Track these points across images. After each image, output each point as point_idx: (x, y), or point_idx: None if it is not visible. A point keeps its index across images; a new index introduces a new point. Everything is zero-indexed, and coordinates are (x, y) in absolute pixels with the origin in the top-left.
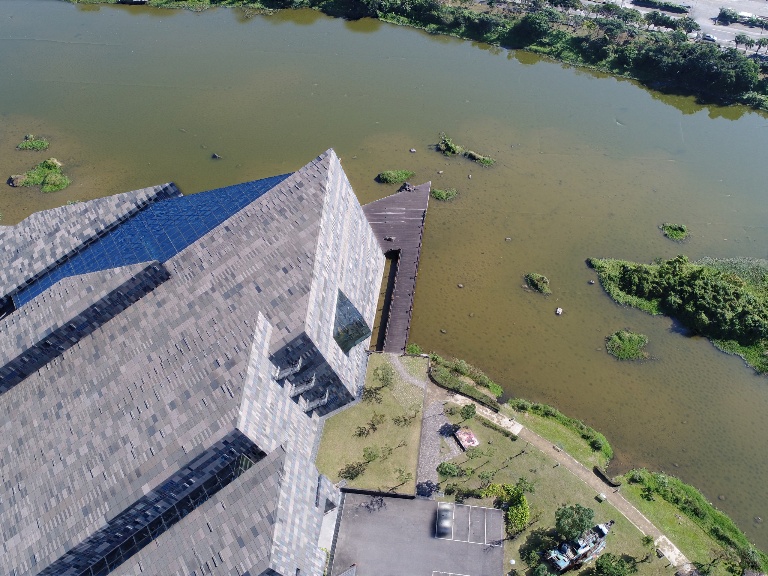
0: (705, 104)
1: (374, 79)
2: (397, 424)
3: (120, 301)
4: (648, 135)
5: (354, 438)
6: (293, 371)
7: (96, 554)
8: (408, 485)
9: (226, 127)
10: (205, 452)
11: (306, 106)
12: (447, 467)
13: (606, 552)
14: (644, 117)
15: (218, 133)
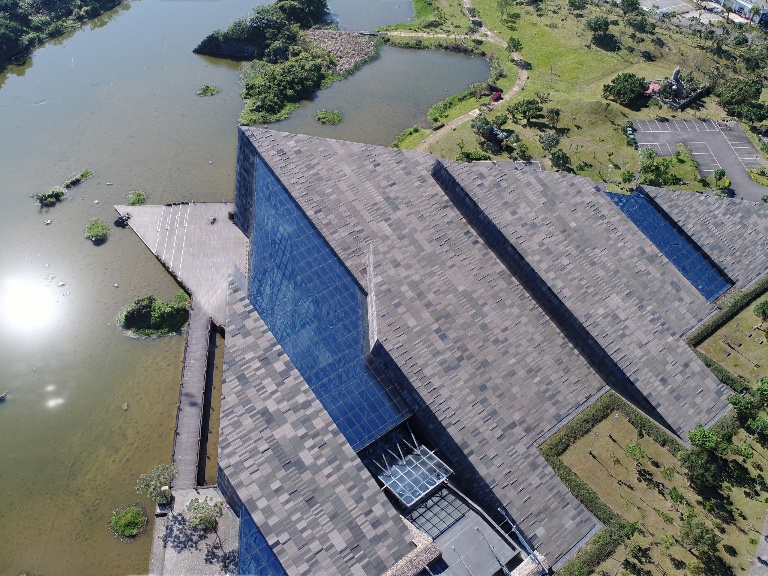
0: (25, 62)
1: None
2: None
3: None
4: (67, 91)
5: None
6: None
7: None
8: None
9: None
10: None
11: None
12: None
13: None
14: (36, 90)
15: None
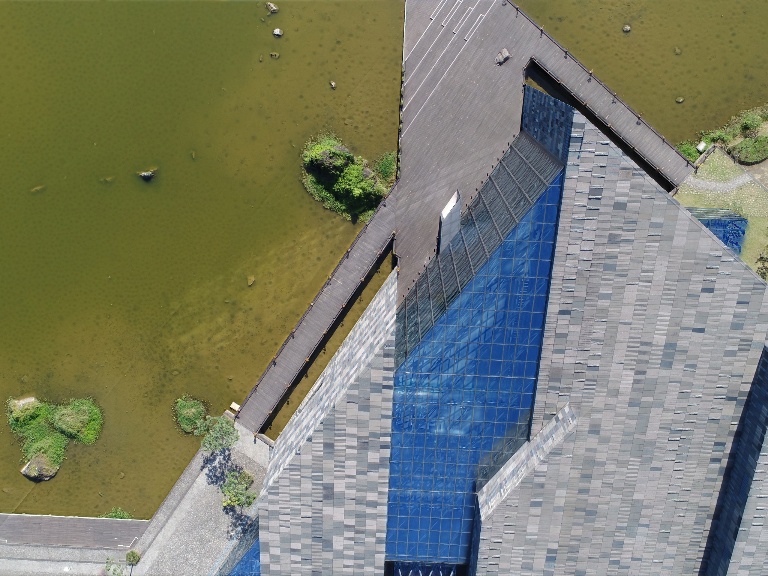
0: None
1: None
2: None
3: None
4: None
5: None
6: None
7: None
8: None
9: (69, 121)
10: None
11: None
12: None
13: None
14: None
15: (80, 142)
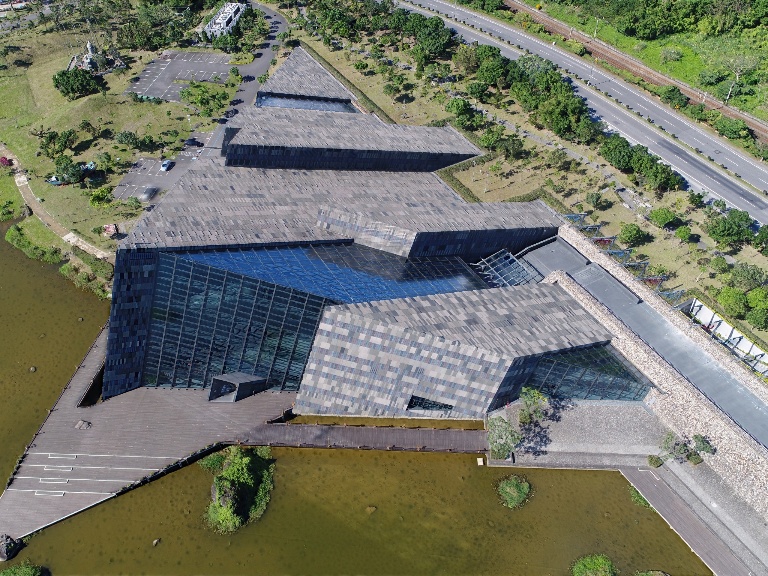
0: None
1: None
2: None
3: None
4: None
5: None
6: None
7: None
8: None
9: None
10: None
11: None
12: (134, 198)
13: None
14: None
15: None
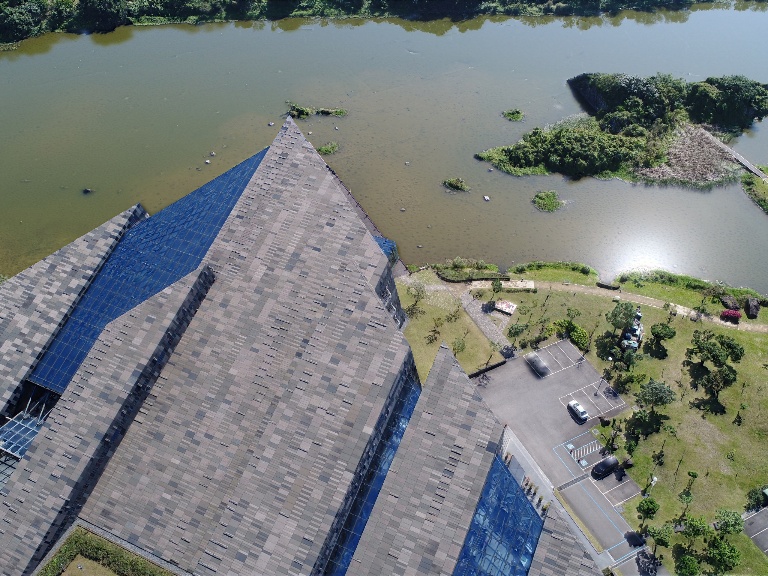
0: (459, 21)
1: (180, 77)
2: (450, 321)
3: (184, 318)
4: (440, 55)
5: (429, 346)
6: (388, 300)
7: (345, 512)
8: (495, 356)
9: (71, 163)
10: (396, 377)
11: (136, 119)
12: (518, 326)
13: (646, 329)
14: (426, 43)
15: (68, 171)
